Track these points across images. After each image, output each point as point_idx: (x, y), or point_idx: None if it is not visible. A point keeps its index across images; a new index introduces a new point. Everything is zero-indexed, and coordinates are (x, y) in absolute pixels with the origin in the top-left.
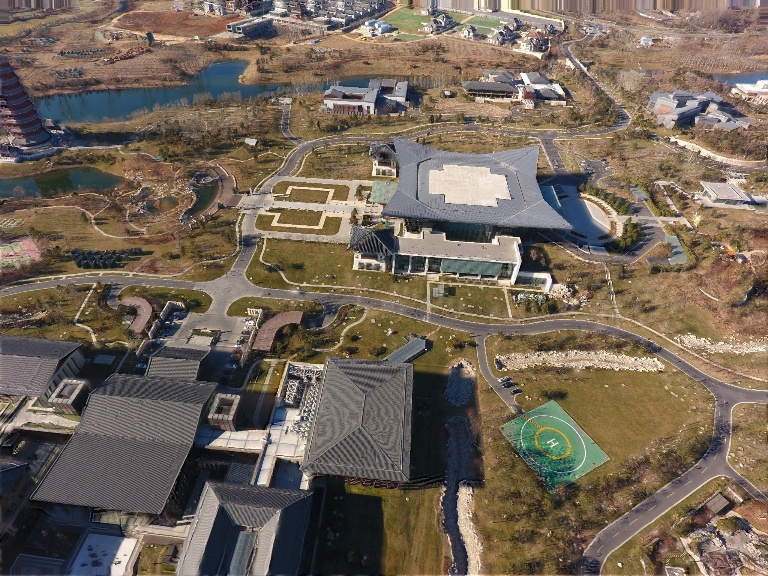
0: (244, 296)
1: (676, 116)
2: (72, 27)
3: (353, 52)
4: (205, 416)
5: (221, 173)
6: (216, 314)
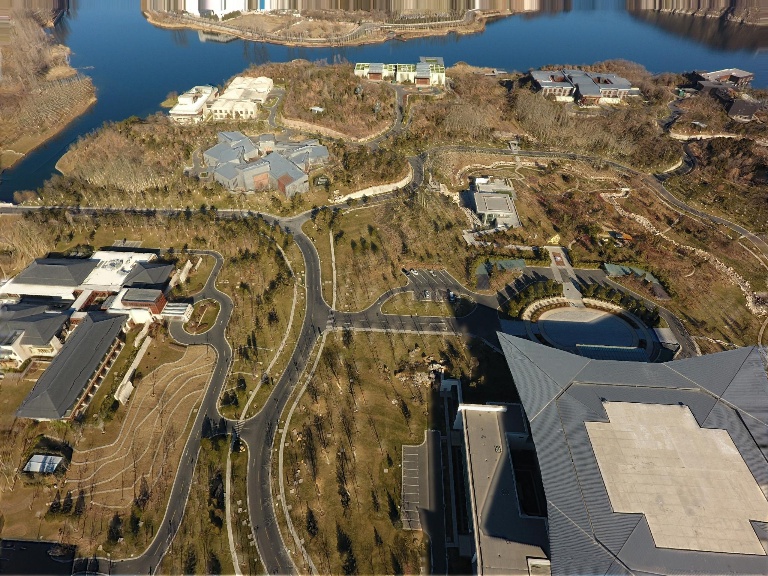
0: None
1: (306, 176)
2: None
3: None
4: None
5: None
6: None
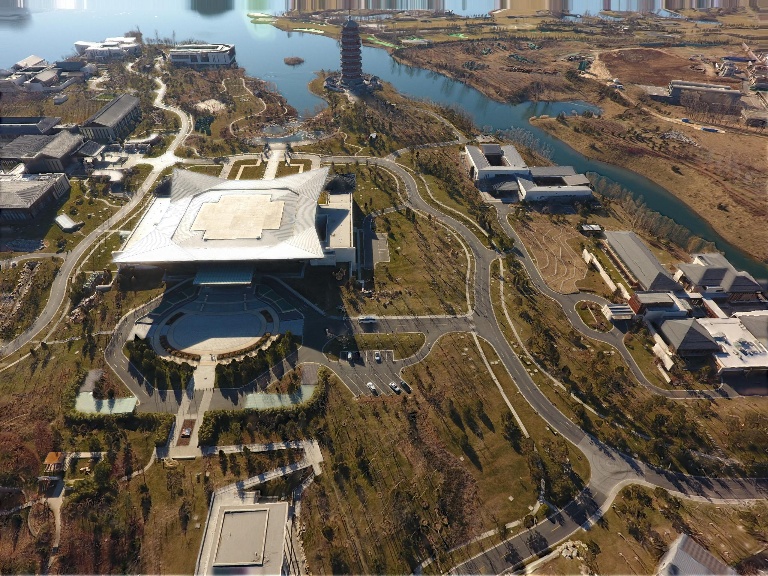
0: (154, 166)
1: (667, 561)
2: (576, 45)
3: (700, 154)
4: (44, 162)
5: (322, 138)
6: (139, 161)
